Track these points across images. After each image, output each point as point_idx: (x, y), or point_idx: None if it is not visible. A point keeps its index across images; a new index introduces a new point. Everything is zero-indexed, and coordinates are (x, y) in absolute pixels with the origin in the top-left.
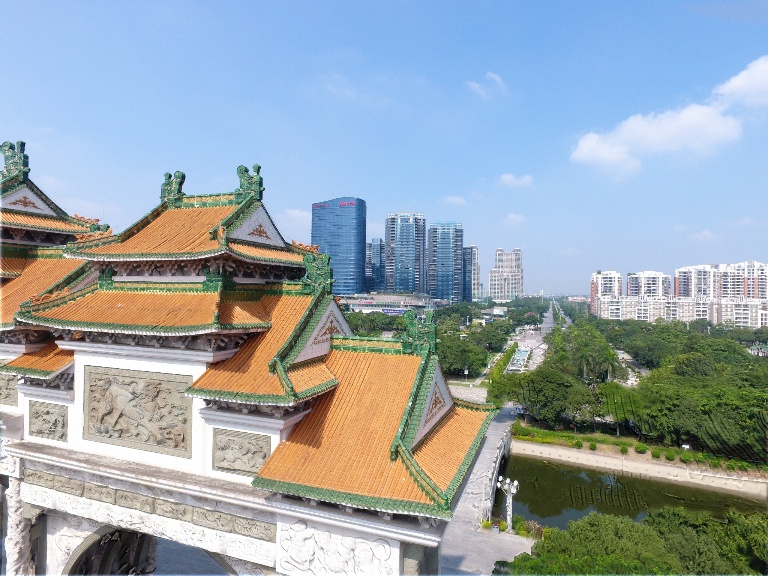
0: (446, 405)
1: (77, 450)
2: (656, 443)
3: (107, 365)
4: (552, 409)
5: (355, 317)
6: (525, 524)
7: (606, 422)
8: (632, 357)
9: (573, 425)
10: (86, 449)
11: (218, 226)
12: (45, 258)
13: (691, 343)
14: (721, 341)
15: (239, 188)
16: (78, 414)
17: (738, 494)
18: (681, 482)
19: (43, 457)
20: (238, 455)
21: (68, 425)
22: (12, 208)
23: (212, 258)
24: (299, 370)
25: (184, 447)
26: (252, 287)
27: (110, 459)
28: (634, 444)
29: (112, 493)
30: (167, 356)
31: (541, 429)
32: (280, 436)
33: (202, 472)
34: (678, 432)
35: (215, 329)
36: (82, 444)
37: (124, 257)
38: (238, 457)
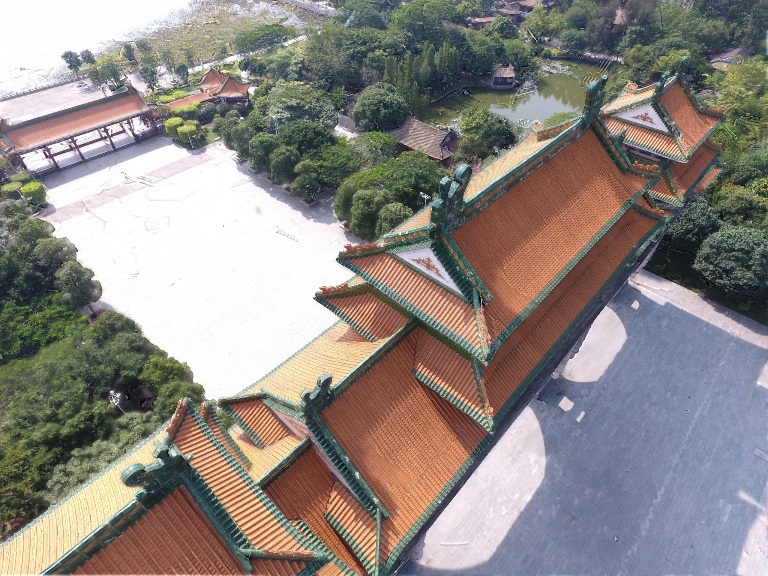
0: None
1: None
2: None
3: None
4: None
5: None
6: None
7: None
8: None
9: None
10: None
11: None
12: None
13: None
14: None
15: None
16: None
17: None
18: None
19: None
20: None
21: None
22: (416, 265)
23: None
24: None
25: None
26: None
27: None
28: None
29: None
30: None
31: None
32: None
33: None
34: None
35: None
36: None
37: None
38: None
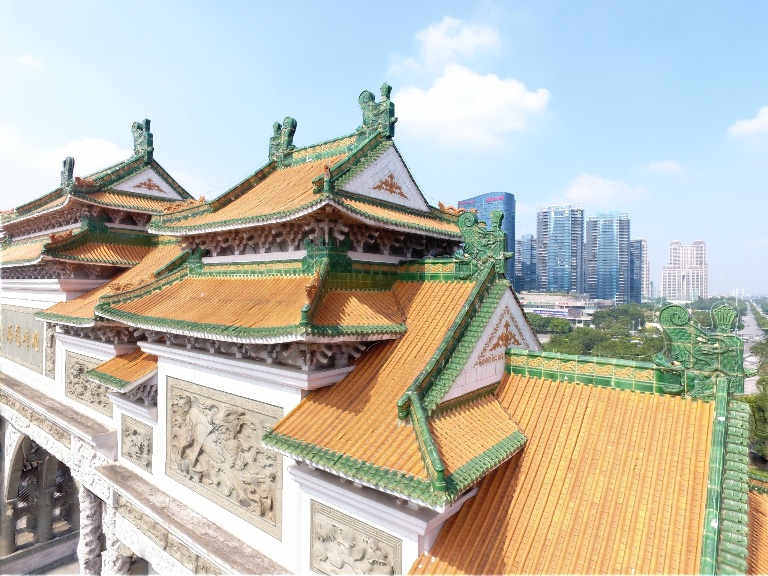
0: None
1: (160, 488)
2: None
3: (188, 378)
4: None
5: None
6: None
7: None
8: None
9: None
10: (168, 489)
11: None
12: (164, 245)
13: None
14: None
15: (362, 125)
16: (161, 440)
17: None
18: None
19: (122, 493)
20: (347, 559)
21: (153, 452)
22: (136, 191)
23: (313, 219)
24: (453, 413)
25: (272, 519)
26: (378, 268)
27: (189, 511)
28: None
29: (193, 559)
30: (249, 373)
31: None
32: (419, 544)
33: (296, 568)
34: None
35: (301, 335)
36: (164, 481)
37: (205, 227)
38: (347, 562)
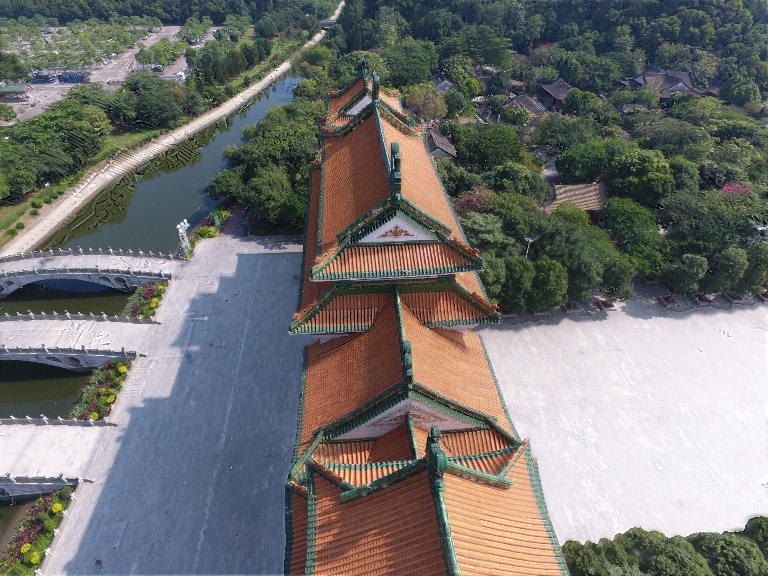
0: None
1: None
2: (22, 198)
3: None
4: None
5: None
6: (191, 240)
7: None
8: None
9: None
10: None
11: None
12: None
13: None
14: None
15: None
16: None
17: (103, 189)
18: (83, 203)
19: None
20: None
21: None
22: None
23: None
24: None
25: None
26: None
27: None
28: None
29: None
30: None
31: None
32: None
33: None
34: None
35: None
36: None
37: None
38: None
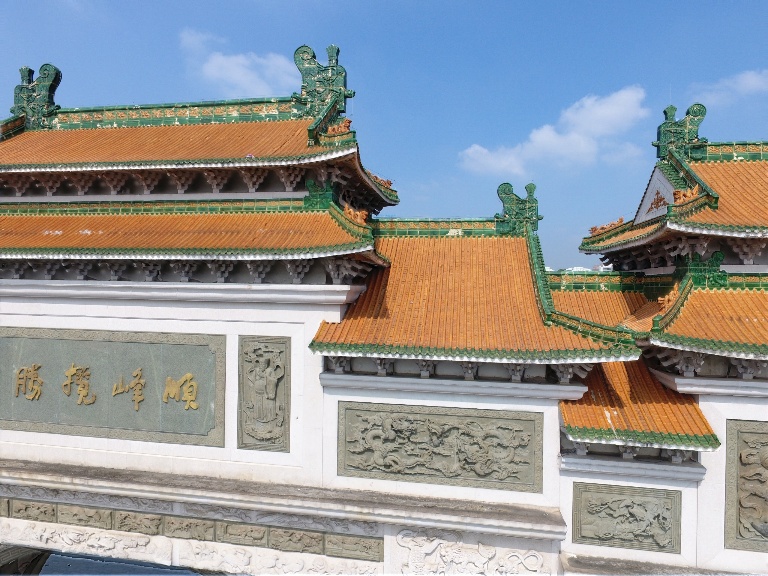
0: None
1: (711, 568)
2: None
3: None
4: None
5: None
6: None
7: None
8: None
9: None
10: (735, 565)
11: None
12: (398, 235)
13: None
14: None
15: None
16: (712, 505)
17: None
18: None
19: None
20: None
21: (682, 524)
22: None
23: None
24: None
25: None
26: None
27: None
28: None
29: None
30: None
31: None
32: None
33: None
34: None
35: None
36: (724, 557)
37: None
38: None
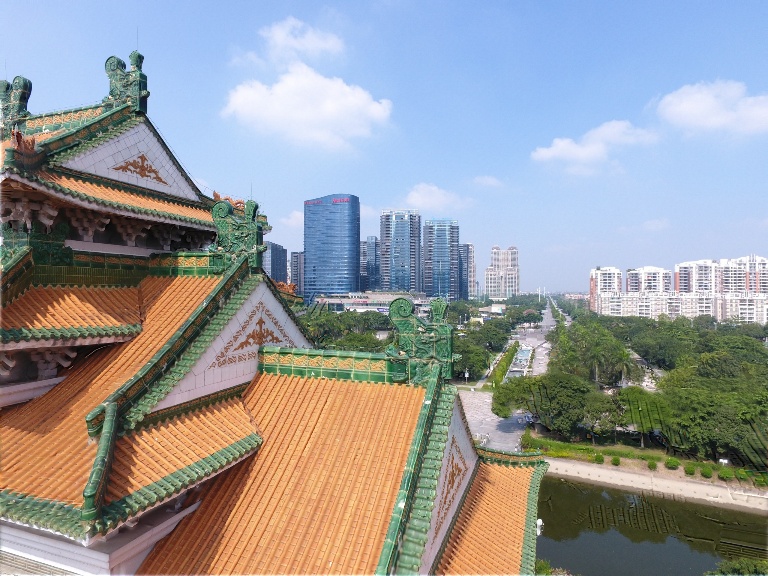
0: (468, 469)
1: None
2: (687, 456)
3: None
4: (567, 418)
5: (348, 316)
6: (552, 574)
7: (629, 432)
8: (641, 356)
9: (590, 435)
10: None
11: (38, 144)
12: None
13: (705, 340)
14: (738, 338)
15: (109, 96)
16: None
17: None
18: (723, 504)
19: None
20: None
21: None
22: None
23: (5, 198)
24: (174, 422)
25: None
26: (117, 261)
27: None
28: (663, 458)
29: None
30: None
31: (554, 440)
32: None
33: None
34: (714, 444)
35: None
36: None
37: None
38: None
